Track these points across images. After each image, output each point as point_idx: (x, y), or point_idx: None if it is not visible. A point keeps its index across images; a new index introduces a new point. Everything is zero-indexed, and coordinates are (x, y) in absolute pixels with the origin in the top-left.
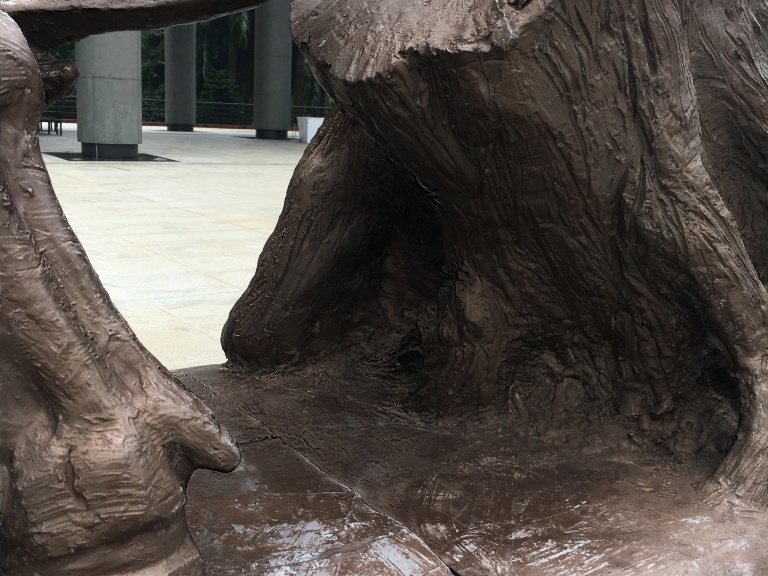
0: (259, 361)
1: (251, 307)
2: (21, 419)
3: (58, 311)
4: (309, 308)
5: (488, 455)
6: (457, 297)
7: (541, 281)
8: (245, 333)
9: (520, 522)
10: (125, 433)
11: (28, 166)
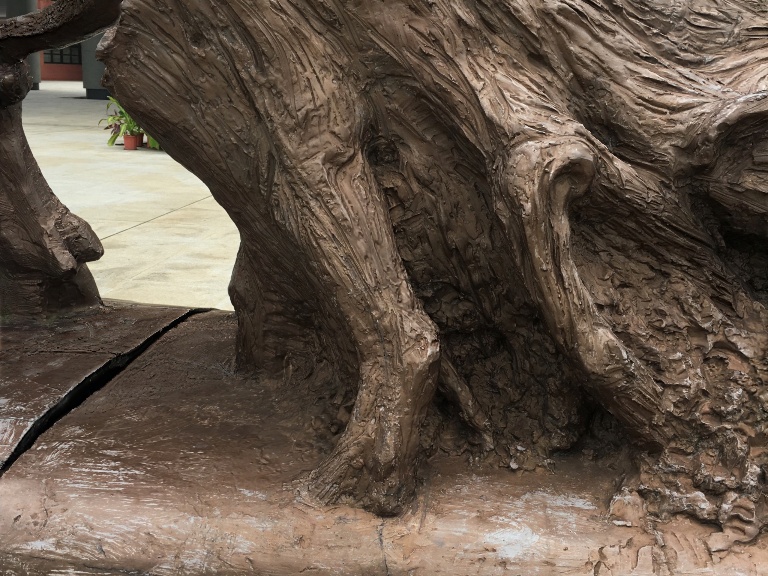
0: None
1: None
2: None
3: None
4: None
5: (220, 405)
6: None
7: (271, 262)
8: (230, 285)
9: (131, 447)
10: None
11: None
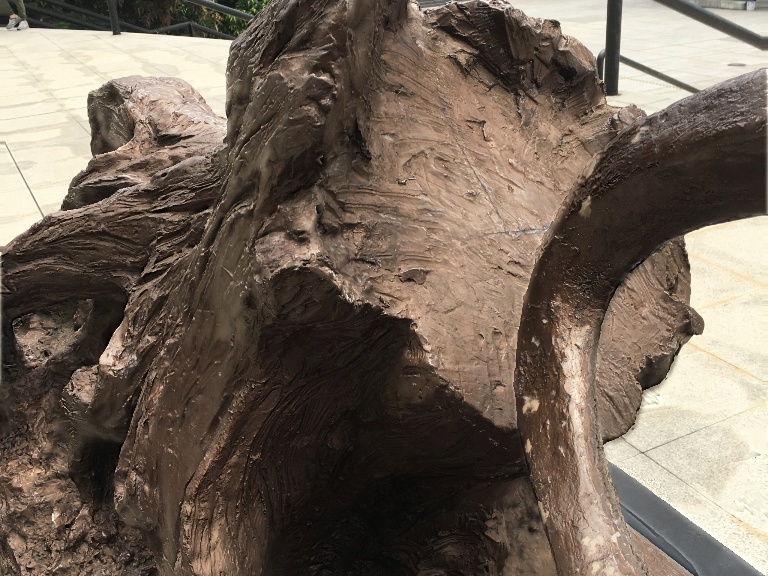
0: None
1: None
2: None
3: None
4: None
5: None
6: (499, 543)
7: None
8: None
9: None
10: None
11: None
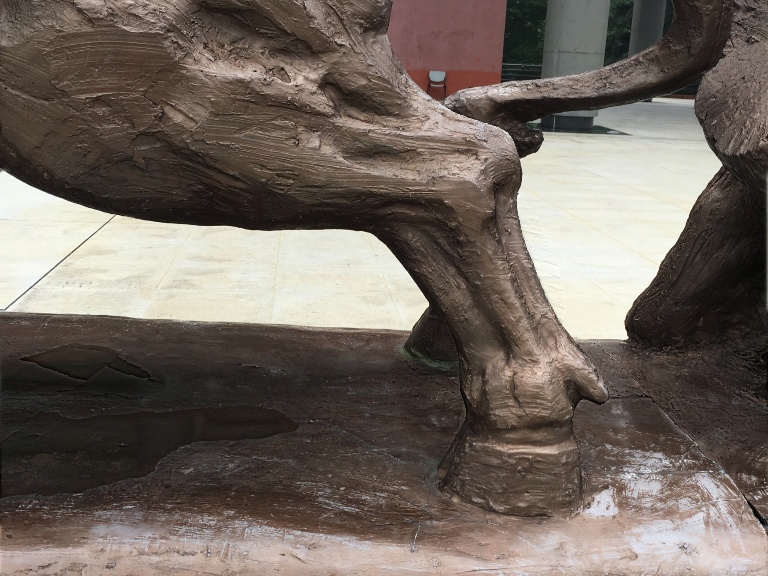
0: (651, 341)
1: (650, 300)
2: (491, 353)
3: (516, 299)
4: (695, 306)
5: None
6: None
7: None
8: (643, 319)
9: None
10: (544, 370)
11: (509, 217)
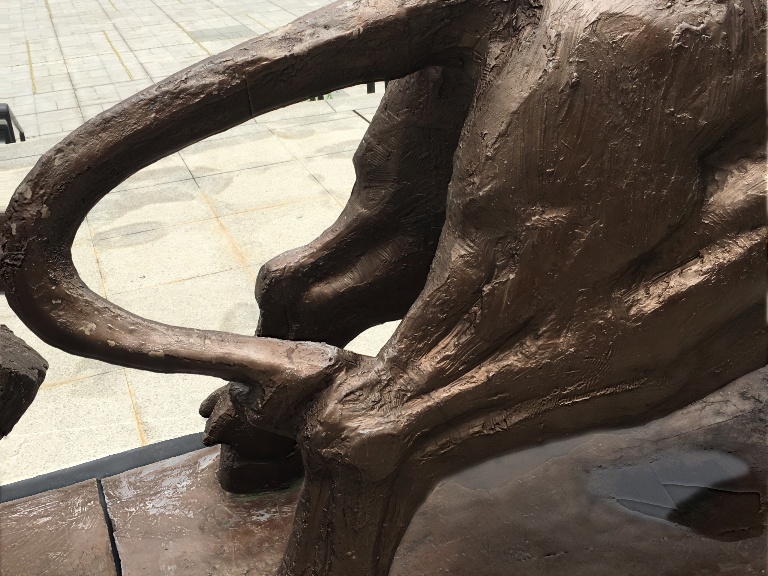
0: None
1: None
2: None
3: None
4: None
5: None
6: None
7: None
8: None
9: None
10: None
11: None
